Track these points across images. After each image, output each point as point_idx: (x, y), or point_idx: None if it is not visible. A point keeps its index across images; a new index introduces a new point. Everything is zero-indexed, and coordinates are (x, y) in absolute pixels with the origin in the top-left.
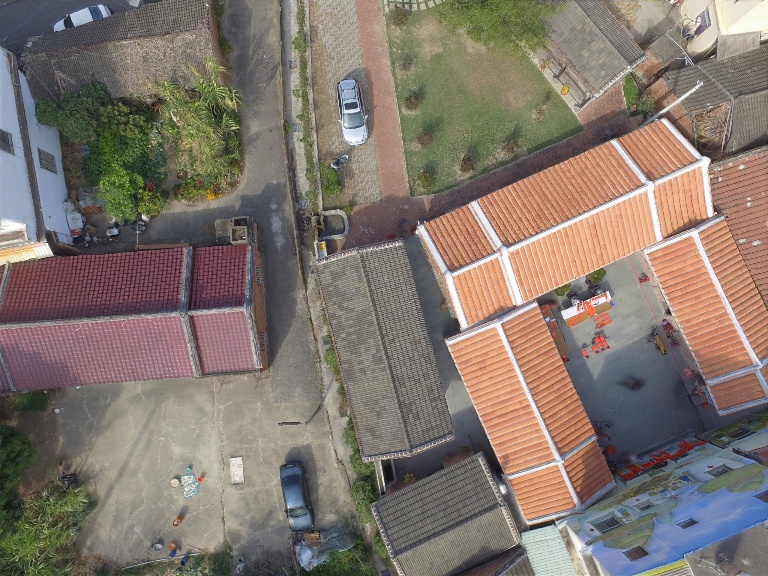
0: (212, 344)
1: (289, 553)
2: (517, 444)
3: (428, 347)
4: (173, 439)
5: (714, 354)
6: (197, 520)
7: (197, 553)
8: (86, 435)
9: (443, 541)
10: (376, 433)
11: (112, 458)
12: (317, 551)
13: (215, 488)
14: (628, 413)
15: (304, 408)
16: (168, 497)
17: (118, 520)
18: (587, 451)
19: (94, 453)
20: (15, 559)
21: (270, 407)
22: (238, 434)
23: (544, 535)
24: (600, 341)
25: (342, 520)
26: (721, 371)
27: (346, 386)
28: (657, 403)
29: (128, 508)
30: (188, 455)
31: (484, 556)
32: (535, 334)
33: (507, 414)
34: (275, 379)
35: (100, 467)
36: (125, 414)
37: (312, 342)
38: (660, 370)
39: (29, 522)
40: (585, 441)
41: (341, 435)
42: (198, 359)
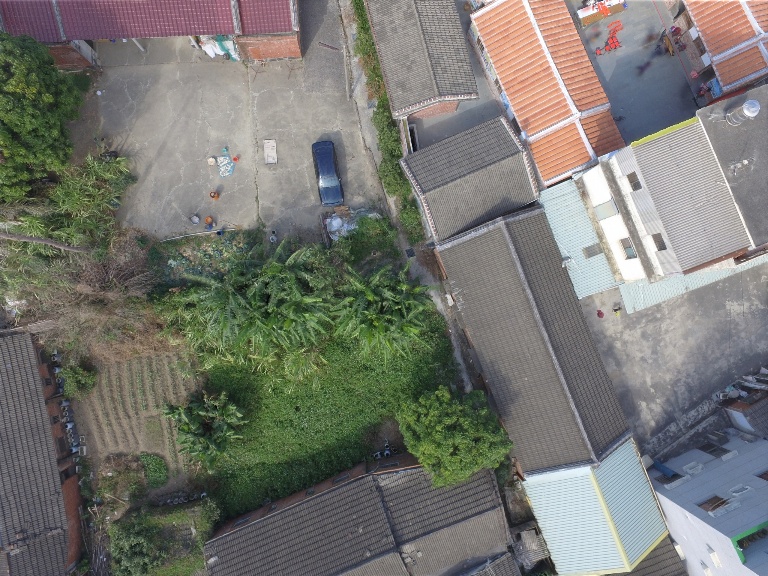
0: (252, 1)
1: (319, 230)
2: (537, 106)
3: (455, 14)
4: (210, 123)
5: (720, 31)
6: (232, 198)
7: (232, 229)
8: (127, 116)
9: (468, 185)
10: (406, 86)
11: (151, 138)
12: (347, 221)
13: (249, 169)
14: (638, 113)
15: (334, 98)
16: (205, 176)
17: (157, 196)
18: (602, 117)
19: (134, 133)
20: (61, 210)
21: (302, 96)
22: (272, 119)
23: (561, 190)
24: (613, 42)
25: (369, 202)
26: (726, 46)
27: (378, 47)
28: (665, 105)
29: (166, 185)
30: (224, 138)
31: (505, 208)
32: (555, 8)
33: (528, 79)
34: (307, 70)
35: (140, 146)
36: (164, 98)
37: (342, 37)
38: (668, 74)
39: (74, 179)
40: (600, 105)
41: (369, 125)
42: (239, 14)
